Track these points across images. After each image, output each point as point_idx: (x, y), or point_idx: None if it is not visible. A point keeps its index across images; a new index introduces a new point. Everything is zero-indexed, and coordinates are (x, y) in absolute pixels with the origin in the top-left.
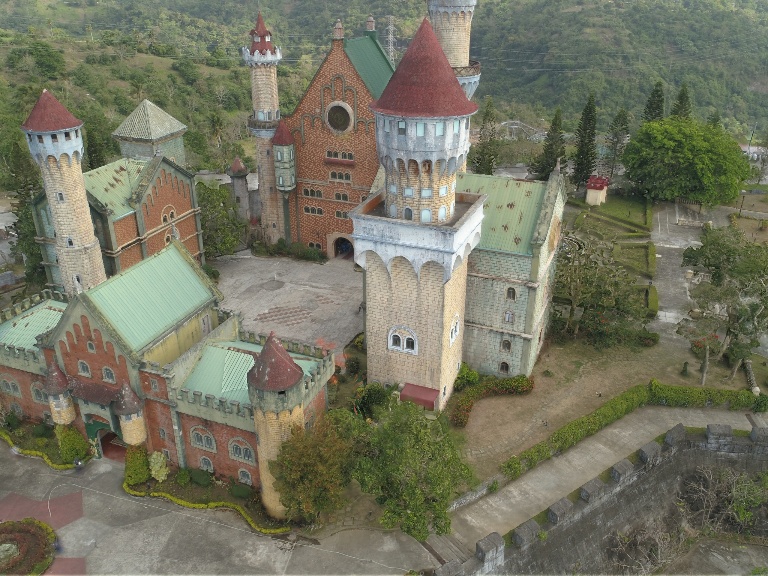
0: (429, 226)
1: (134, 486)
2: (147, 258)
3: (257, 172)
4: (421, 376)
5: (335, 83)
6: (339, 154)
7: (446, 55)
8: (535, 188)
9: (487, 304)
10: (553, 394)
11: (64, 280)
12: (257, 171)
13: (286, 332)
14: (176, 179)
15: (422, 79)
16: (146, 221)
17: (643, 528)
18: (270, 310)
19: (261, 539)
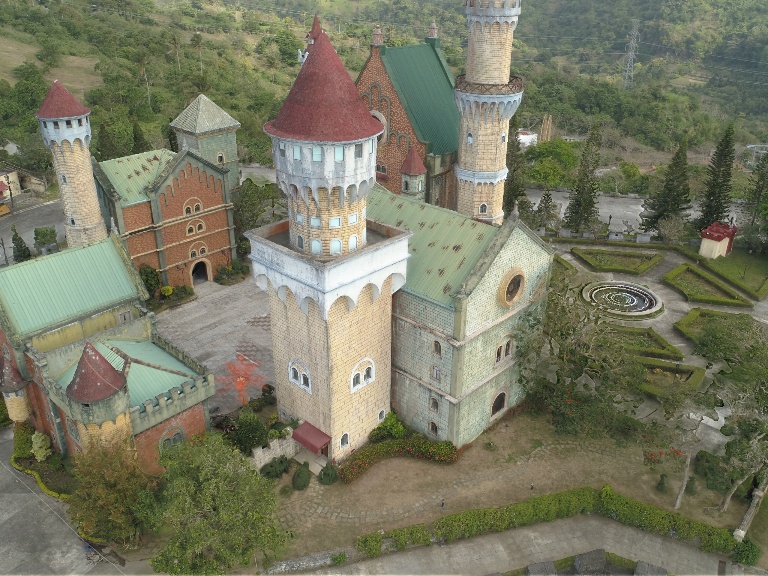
0: (302, 259)
1: (18, 459)
2: None
3: None
4: (316, 417)
5: (373, 91)
6: None
7: (478, 70)
8: (489, 232)
9: (416, 354)
10: (479, 472)
11: None
12: None
13: (265, 340)
14: (205, 173)
15: (305, 97)
16: (164, 210)
17: None
18: (268, 315)
19: (80, 543)
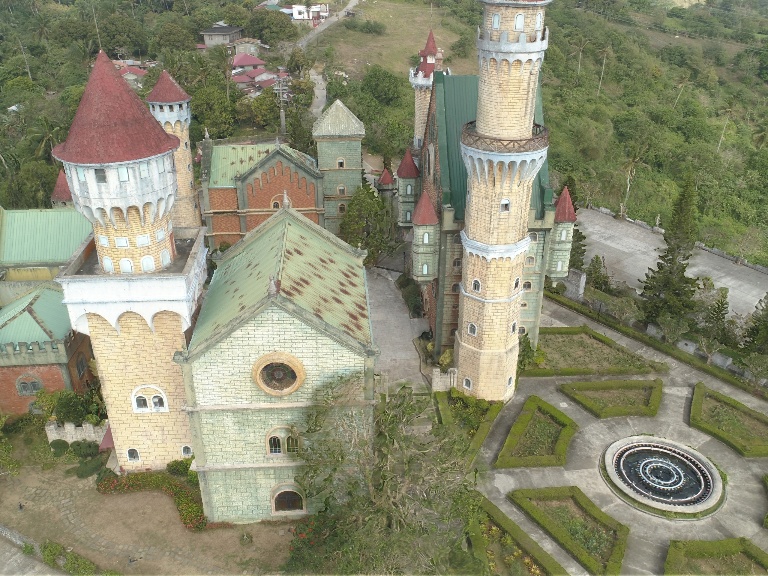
0: None
1: None
2: (73, 209)
3: (619, 219)
4: None
5: None
6: None
7: (478, 115)
8: None
9: None
10: (203, 555)
11: None
12: (620, 218)
13: None
14: (298, 174)
15: None
16: (251, 199)
17: None
18: None
19: None
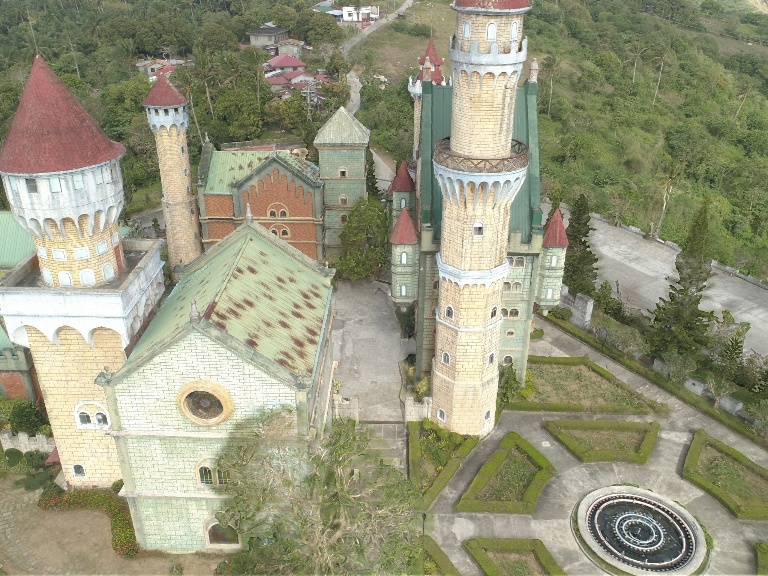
0: None
1: None
2: None
3: (649, 239)
4: None
5: None
6: None
7: None
8: None
9: None
10: None
11: None
12: (650, 238)
13: None
14: (295, 183)
15: None
16: None
17: None
18: None
19: None
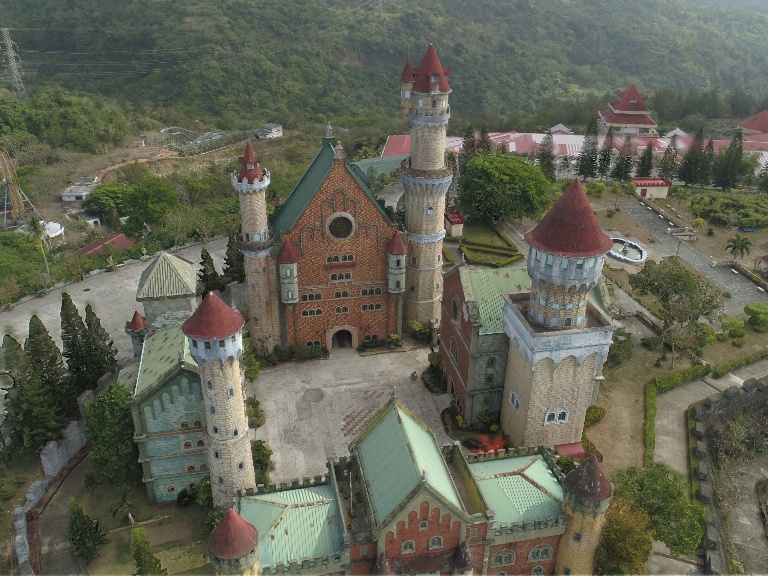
0: (598, 330)
1: None
2: (404, 427)
3: (115, 270)
4: (568, 437)
5: (336, 197)
6: (340, 258)
7: (433, 160)
8: None
9: None
10: (612, 412)
11: (224, 472)
12: (114, 269)
13: None
14: None
15: (588, 225)
16: None
17: (722, 482)
18: (345, 421)
19: None
